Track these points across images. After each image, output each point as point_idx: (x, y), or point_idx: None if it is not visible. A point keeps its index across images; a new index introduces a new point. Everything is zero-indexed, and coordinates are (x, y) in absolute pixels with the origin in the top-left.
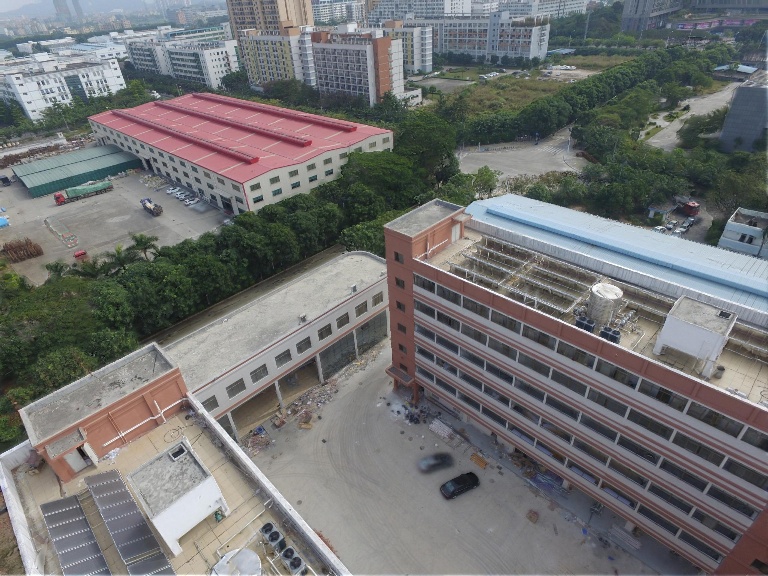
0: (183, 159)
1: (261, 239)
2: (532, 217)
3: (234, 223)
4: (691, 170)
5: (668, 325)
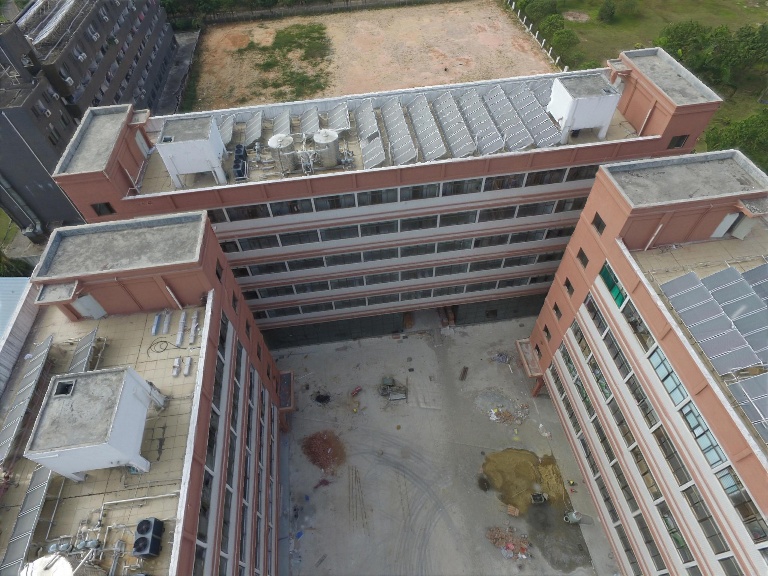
0: None
1: None
2: None
3: None
4: None
5: (118, 445)
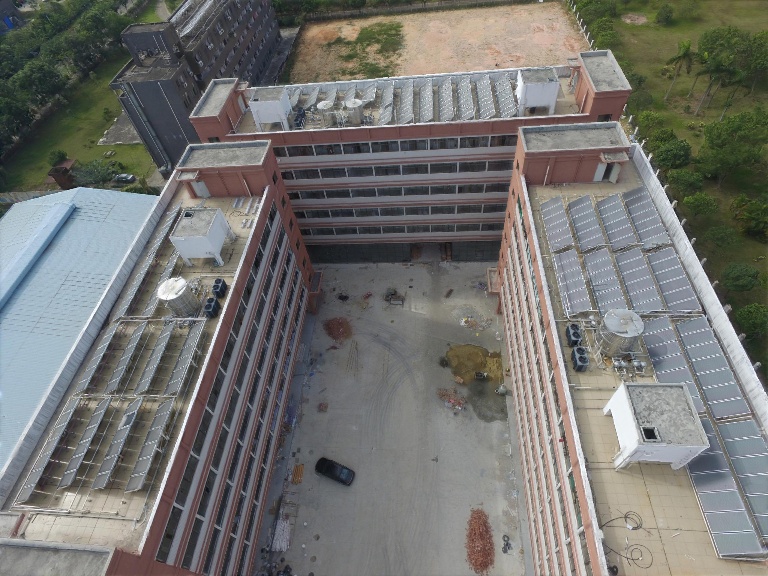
0: None
1: None
2: None
3: None
4: None
5: None
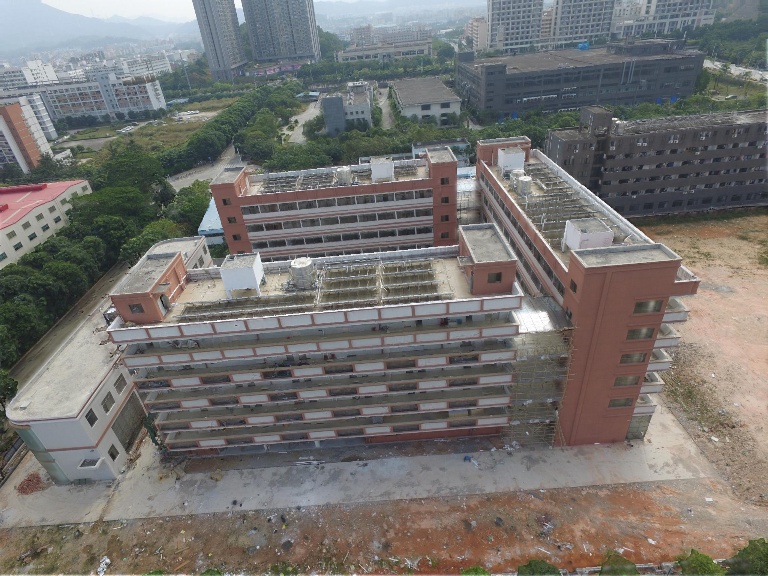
0: None
1: (48, 277)
2: None
3: (3, 276)
4: (324, 150)
5: (373, 169)
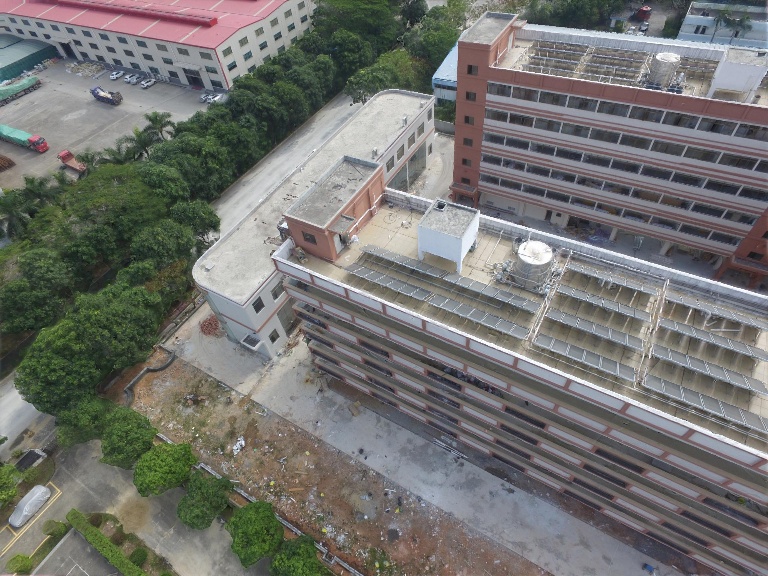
0: (123, 34)
1: (273, 100)
2: None
3: (238, 88)
4: None
5: (723, 70)
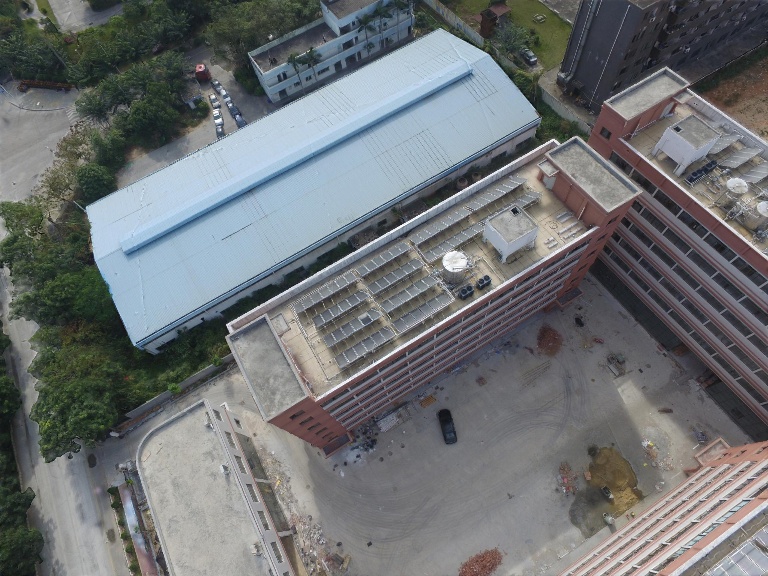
0: None
1: None
2: (173, 217)
3: None
4: (156, 35)
5: None
